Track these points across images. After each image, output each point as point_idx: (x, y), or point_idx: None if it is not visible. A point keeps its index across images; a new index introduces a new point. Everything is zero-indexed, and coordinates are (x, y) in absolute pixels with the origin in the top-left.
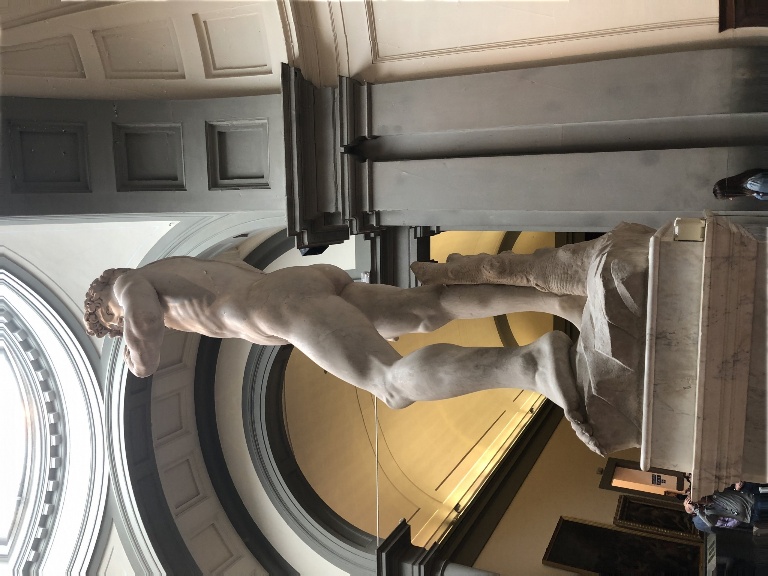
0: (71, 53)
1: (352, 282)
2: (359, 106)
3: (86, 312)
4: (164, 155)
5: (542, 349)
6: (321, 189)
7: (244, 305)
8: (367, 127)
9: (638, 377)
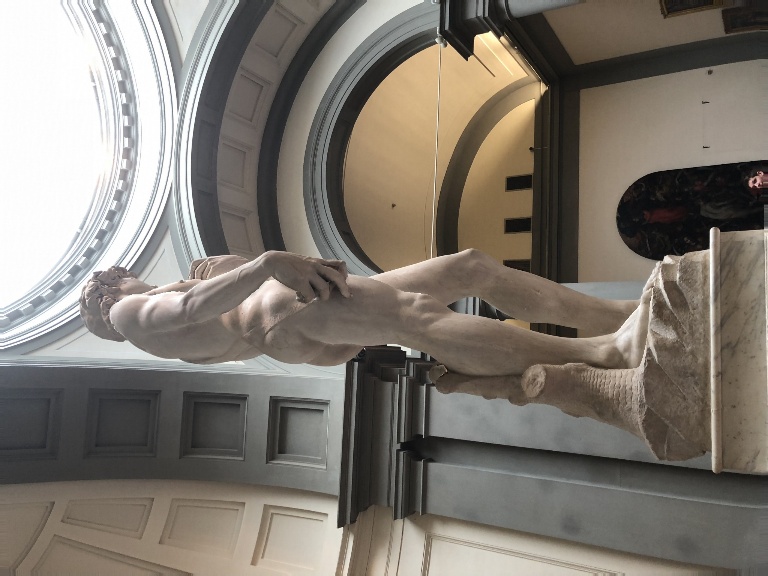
0: None
1: (311, 342)
2: None
3: None
4: None
5: None
6: None
7: None
8: None
9: None
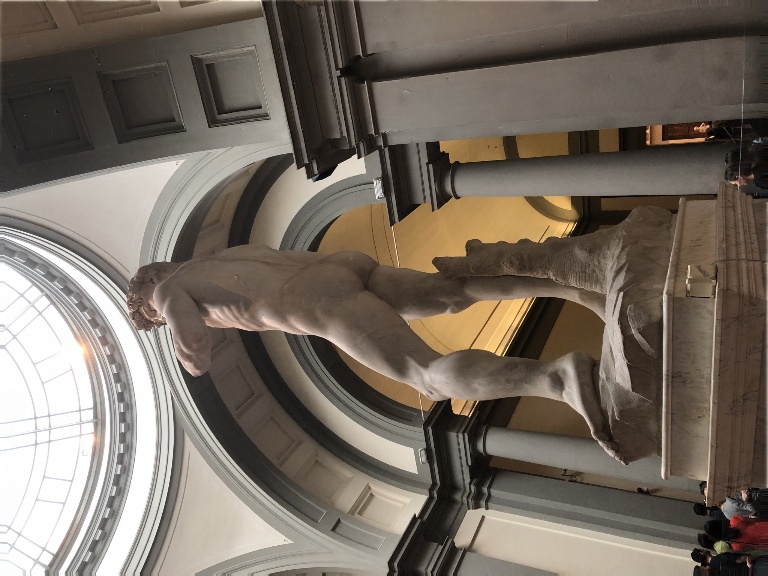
0: (36, 2)
1: (376, 265)
2: (349, 23)
3: (130, 311)
4: (156, 96)
5: (567, 371)
6: (323, 116)
7: (280, 310)
8: (361, 46)
9: (657, 406)
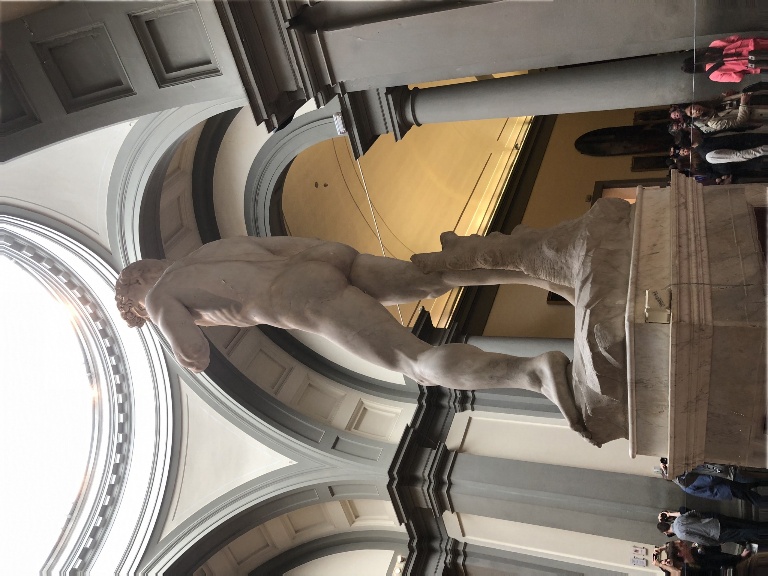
0: None
1: (356, 254)
2: None
3: (122, 313)
4: (98, 60)
5: (544, 371)
6: (276, 69)
7: (271, 312)
8: None
9: (623, 404)
